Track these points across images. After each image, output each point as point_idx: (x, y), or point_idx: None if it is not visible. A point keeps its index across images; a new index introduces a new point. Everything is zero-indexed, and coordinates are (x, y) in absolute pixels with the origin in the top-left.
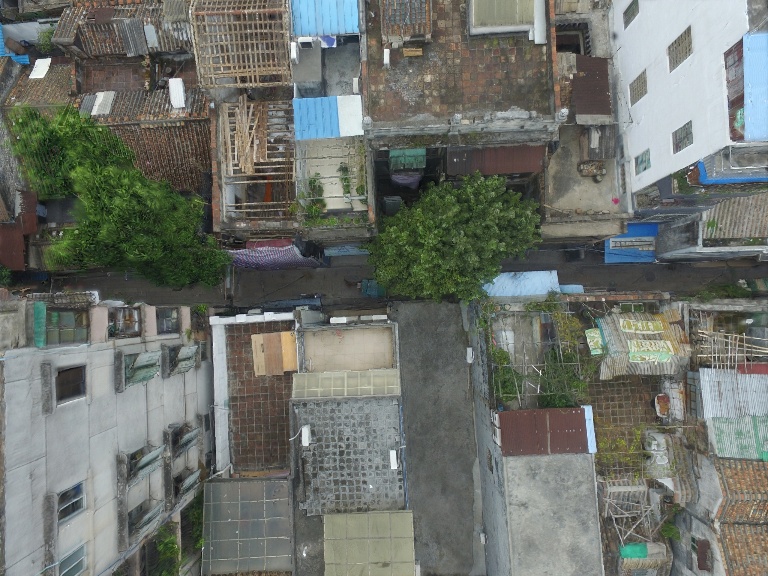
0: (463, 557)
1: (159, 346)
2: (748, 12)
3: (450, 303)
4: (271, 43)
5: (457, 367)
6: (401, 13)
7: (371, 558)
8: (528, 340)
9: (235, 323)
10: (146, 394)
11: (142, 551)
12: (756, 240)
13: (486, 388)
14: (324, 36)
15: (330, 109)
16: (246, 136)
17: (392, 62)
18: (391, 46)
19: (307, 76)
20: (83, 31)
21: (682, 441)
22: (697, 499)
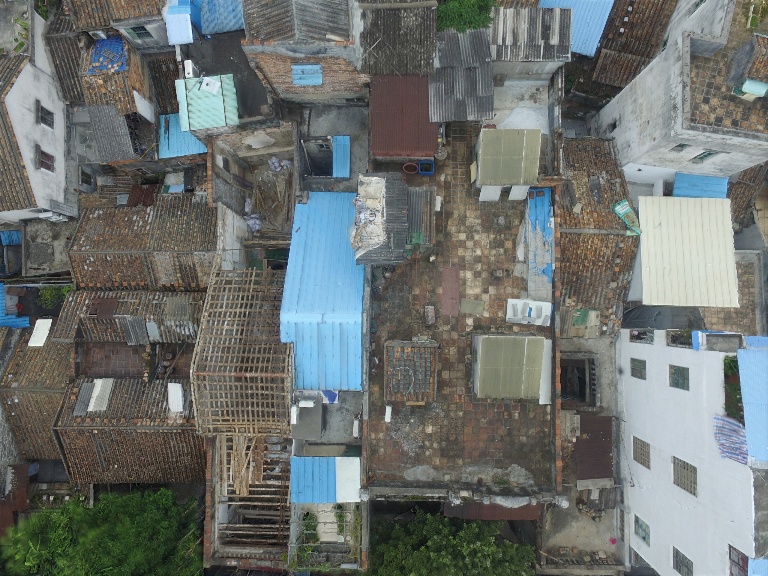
0: None
1: None
2: (755, 538)
3: None
4: (272, 402)
5: None
6: (405, 383)
7: None
8: None
9: None
10: None
11: None
12: None
13: None
14: (326, 390)
15: (328, 471)
16: (242, 457)
17: (394, 411)
18: None
19: (306, 434)
20: (84, 323)
21: None
22: None
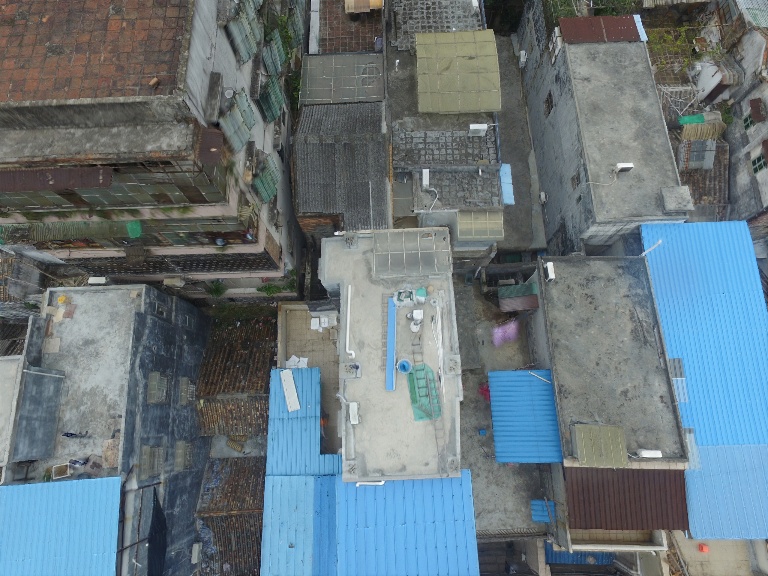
0: (523, 232)
1: None
2: None
3: (502, 36)
4: None
5: (510, 82)
6: None
7: (458, 53)
8: None
9: None
10: None
11: None
12: None
13: (542, 41)
14: None
15: None
16: None
17: None
18: None
19: None
20: None
21: None
22: (743, 78)
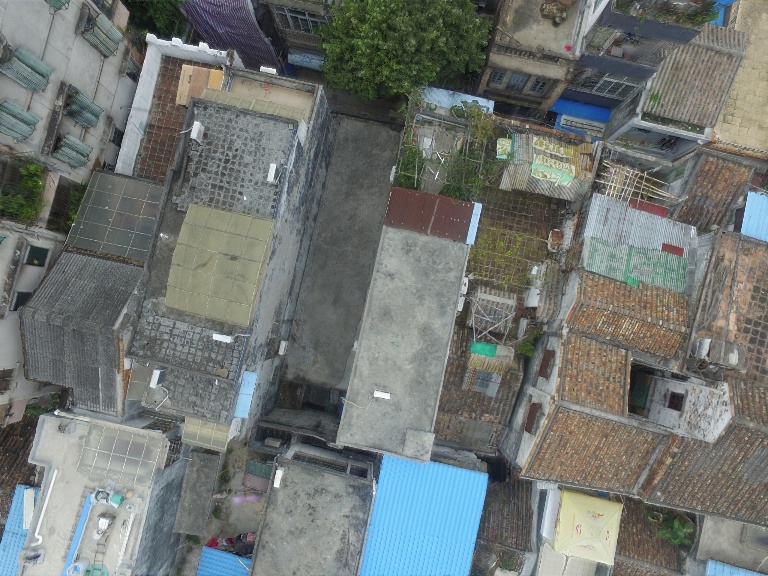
0: (335, 369)
1: (80, 2)
2: None
3: (391, 130)
4: None
5: (381, 191)
6: None
7: (222, 249)
8: (447, 152)
9: (170, 48)
10: (51, 25)
11: (2, 158)
12: (694, 129)
13: None
14: None
15: None
16: None
17: None
18: None
19: None
20: None
21: (561, 267)
22: (557, 315)
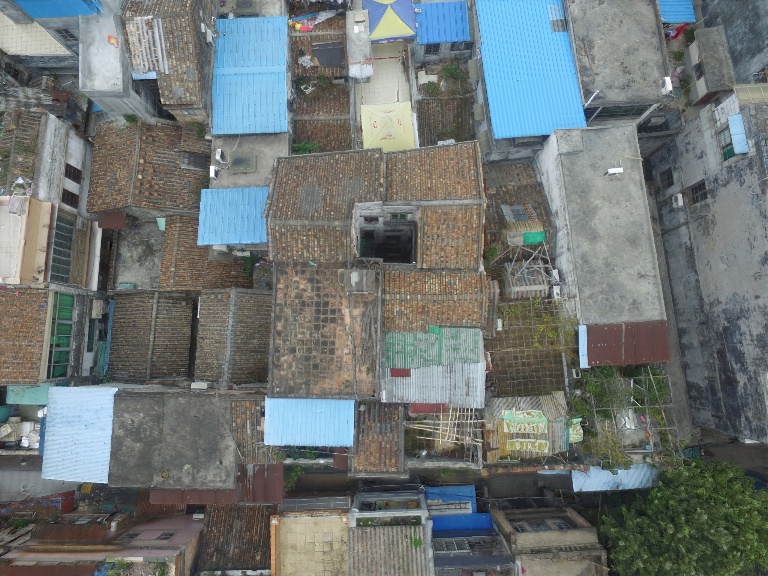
0: None
1: None
2: None
3: None
4: None
5: None
6: None
7: None
8: None
9: None
10: None
11: None
12: (365, 523)
13: None
14: None
15: None
16: None
17: None
18: None
19: None
20: None
21: None
22: None
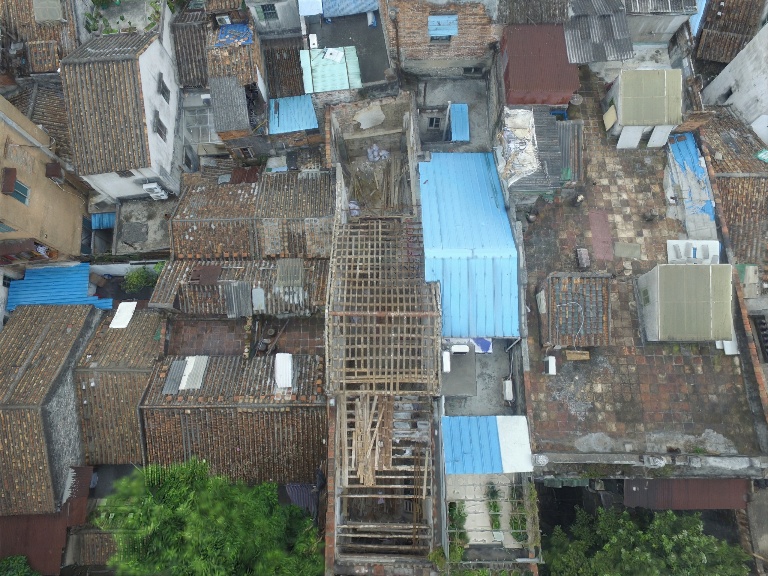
0: None
1: None
2: None
3: None
4: (418, 349)
5: None
6: (574, 322)
7: None
8: None
9: None
10: None
11: None
12: None
13: None
14: (477, 338)
15: (489, 433)
16: (367, 436)
17: None
18: (553, 348)
19: (459, 388)
20: (183, 290)
21: None
22: None
